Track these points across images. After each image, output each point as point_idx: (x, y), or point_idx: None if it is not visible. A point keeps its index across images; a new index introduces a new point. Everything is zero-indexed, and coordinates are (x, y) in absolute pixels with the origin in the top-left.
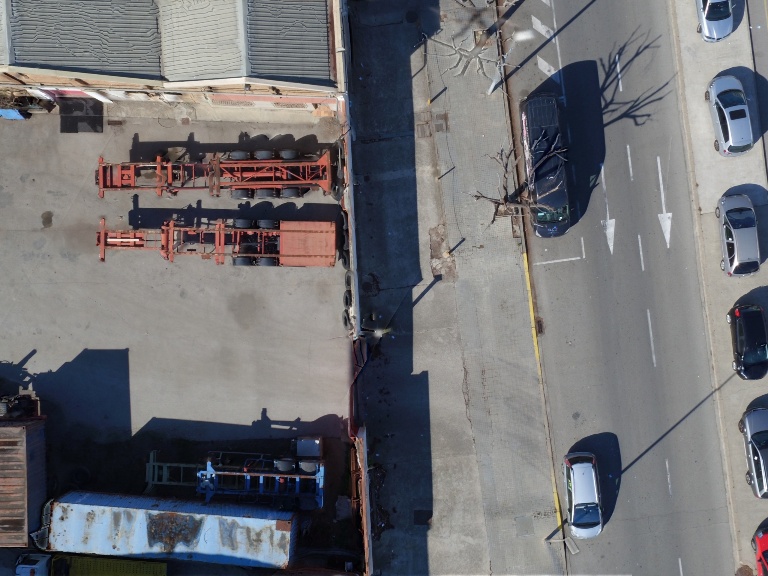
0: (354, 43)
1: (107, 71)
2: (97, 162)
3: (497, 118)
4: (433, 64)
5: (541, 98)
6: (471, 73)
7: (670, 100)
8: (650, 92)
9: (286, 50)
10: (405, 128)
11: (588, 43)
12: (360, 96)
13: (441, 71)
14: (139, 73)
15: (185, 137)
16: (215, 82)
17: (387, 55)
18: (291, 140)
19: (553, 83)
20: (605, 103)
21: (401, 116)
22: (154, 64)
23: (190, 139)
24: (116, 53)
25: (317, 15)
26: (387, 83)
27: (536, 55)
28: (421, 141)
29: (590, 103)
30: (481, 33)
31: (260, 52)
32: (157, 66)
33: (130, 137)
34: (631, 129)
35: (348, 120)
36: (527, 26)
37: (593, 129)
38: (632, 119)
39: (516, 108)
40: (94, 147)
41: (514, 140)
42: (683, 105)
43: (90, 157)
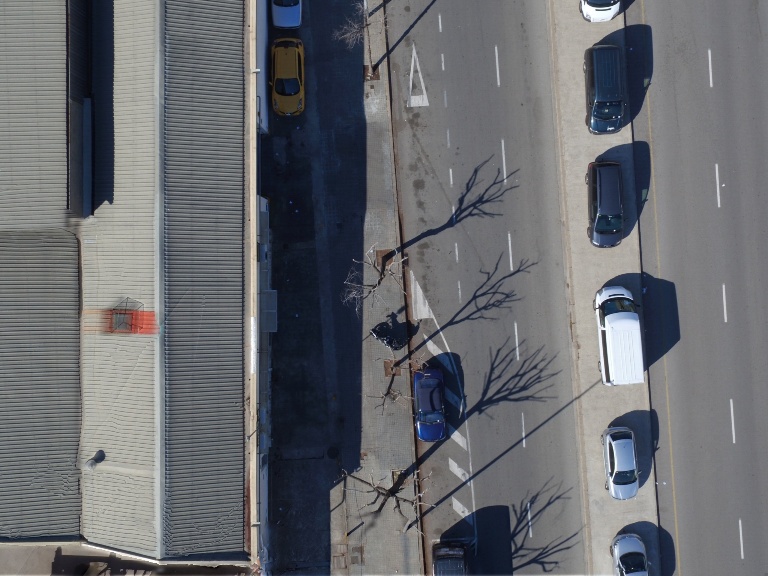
0: (272, 495)
1: (26, 537)
2: (19, 573)
3: (411, 555)
4: (352, 499)
5: (450, 561)
6: (388, 510)
7: (577, 551)
8: (558, 541)
9: (200, 536)
10: (322, 559)
11: (502, 489)
12: (278, 533)
13: (359, 506)
14: (58, 535)
15: (107, 553)
16: (130, 556)
17: (307, 488)
18: (210, 567)
19: (466, 524)
20: (515, 548)
21: (318, 547)
22: (74, 524)
23: (112, 555)
24: (37, 513)
25: (233, 495)
26: (306, 515)
27: (451, 496)
28: (336, 572)
29: (501, 547)
30: (399, 473)
31: (174, 542)
32: (76, 526)
33: (53, 550)
34: (539, 574)
35: (263, 568)
36: (444, 468)
37: (502, 575)
38: (540, 565)
39: (429, 548)
40: (17, 558)
41: (426, 575)
42: (589, 557)
43: (13, 567)
